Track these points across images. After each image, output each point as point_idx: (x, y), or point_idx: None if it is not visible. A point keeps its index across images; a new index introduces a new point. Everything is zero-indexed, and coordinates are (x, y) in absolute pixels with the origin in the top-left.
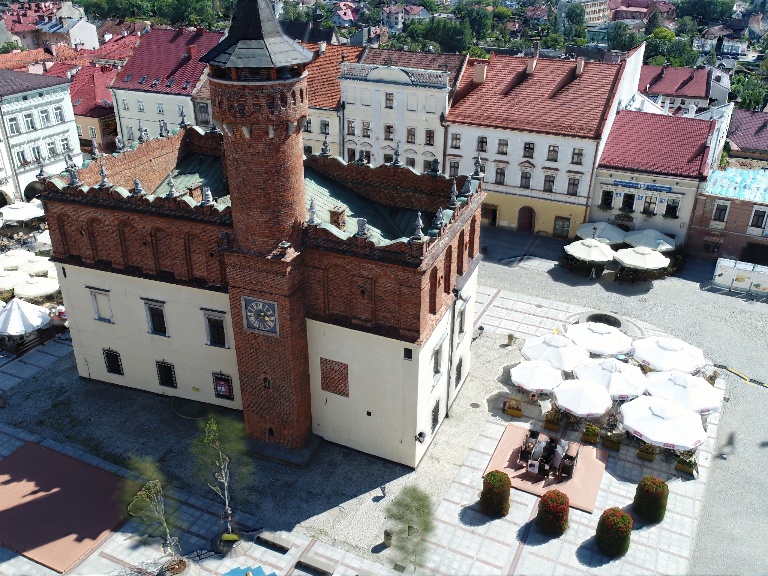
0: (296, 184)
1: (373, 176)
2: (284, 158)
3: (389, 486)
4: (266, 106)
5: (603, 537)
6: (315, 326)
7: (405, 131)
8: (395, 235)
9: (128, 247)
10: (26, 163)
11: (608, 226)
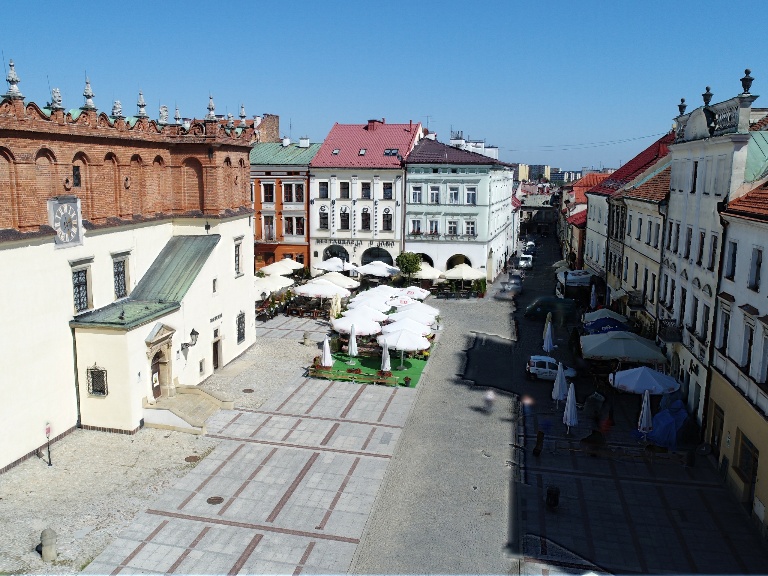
0: None
1: None
2: None
3: None
4: None
5: None
6: None
7: (697, 239)
8: None
9: None
10: (418, 233)
11: None
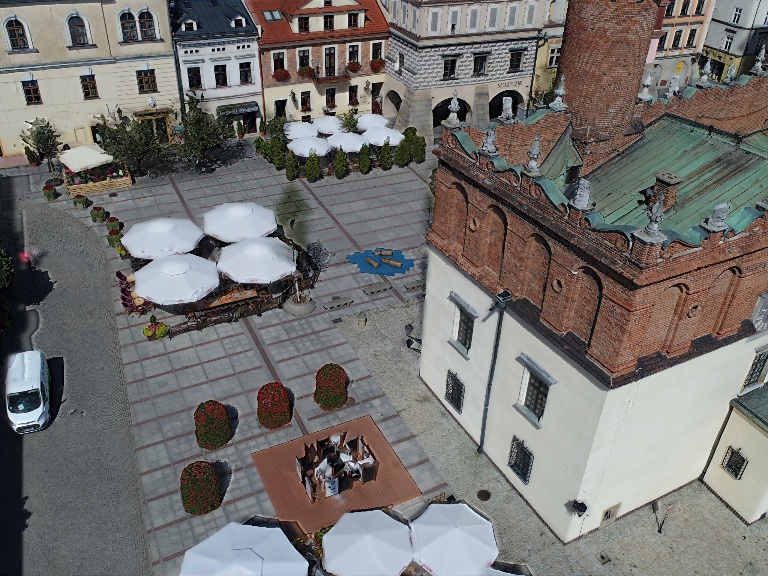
0: None
1: None
2: None
3: (417, 354)
4: None
5: None
6: None
7: None
8: None
9: None
10: None
11: None
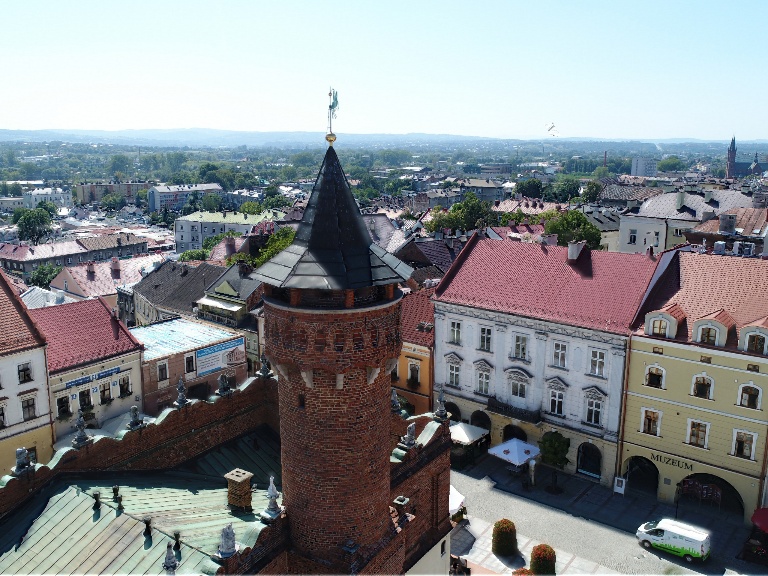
0: None
1: (159, 435)
2: None
3: None
4: None
5: (551, 572)
6: None
7: None
8: None
9: None
10: None
11: (92, 430)
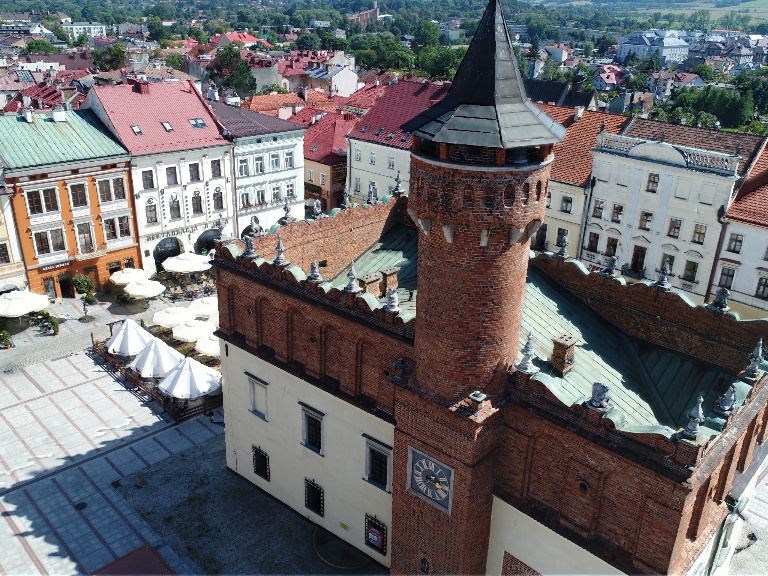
0: (509, 313)
1: (623, 295)
2: (497, 276)
3: None
4: (482, 201)
5: None
6: (504, 508)
7: (667, 222)
8: (643, 385)
9: (295, 338)
10: (248, 205)
11: None
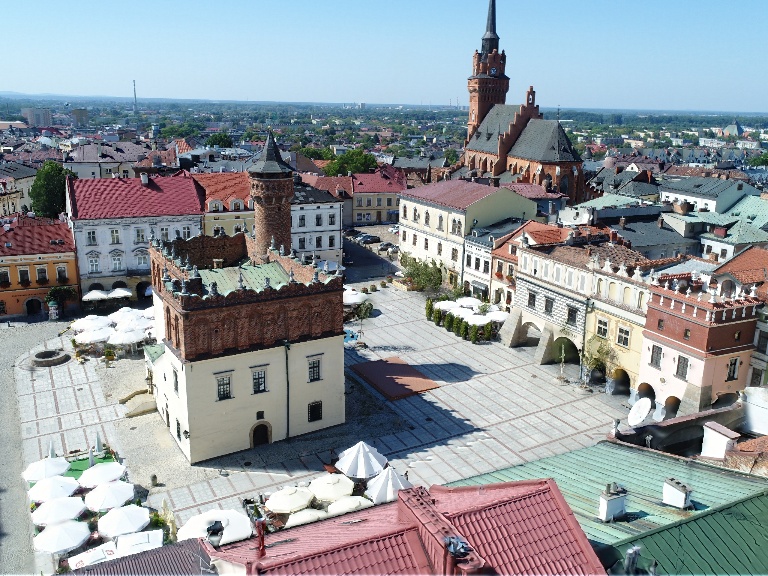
0: None
1: None
2: None
3: None
4: None
5: None
6: None
7: None
8: None
9: None
10: None
11: None
